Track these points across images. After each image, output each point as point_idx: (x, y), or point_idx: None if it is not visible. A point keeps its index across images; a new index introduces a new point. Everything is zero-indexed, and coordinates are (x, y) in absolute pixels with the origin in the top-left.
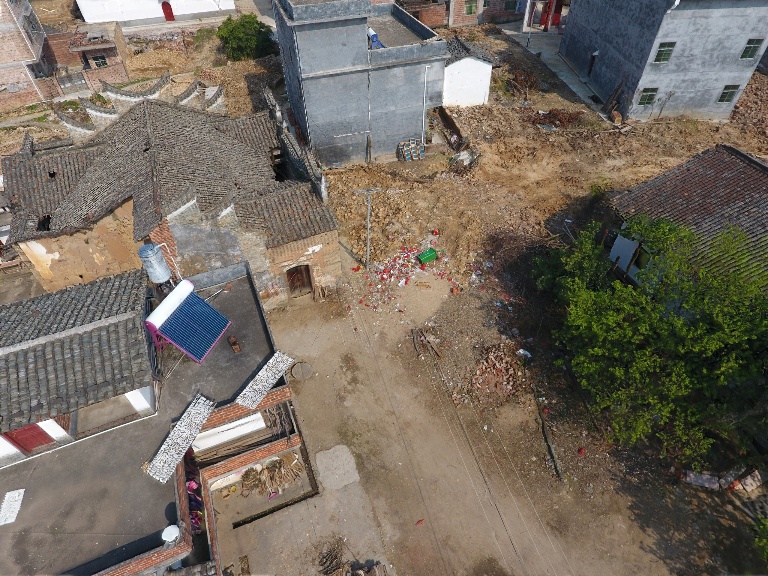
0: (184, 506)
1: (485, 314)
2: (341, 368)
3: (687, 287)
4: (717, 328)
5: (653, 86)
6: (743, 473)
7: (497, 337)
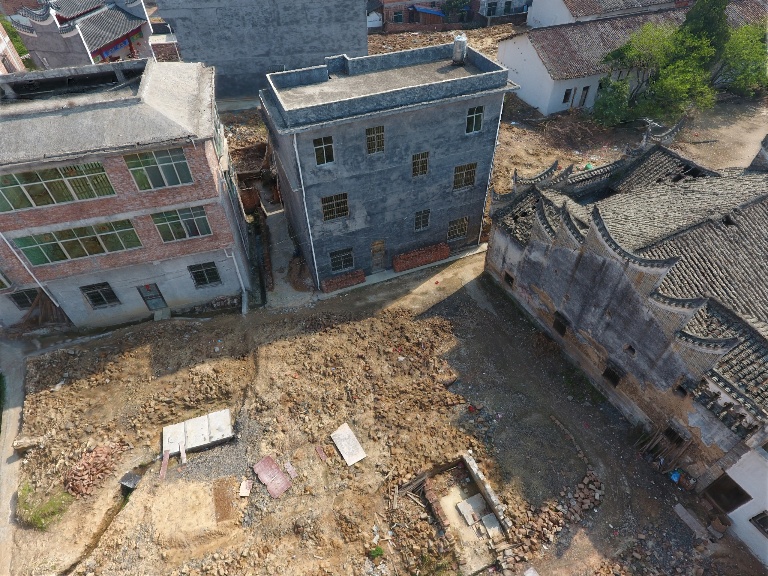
0: None
1: None
2: None
3: None
4: (689, 51)
5: None
6: None
7: None
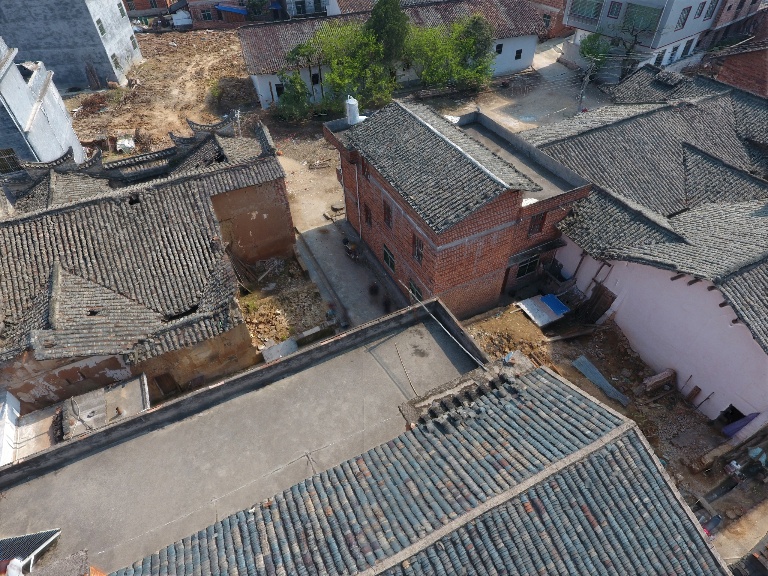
0: (465, 121)
1: (303, 143)
2: (336, 192)
3: (343, 47)
4: None
5: (112, 53)
6: (391, 99)
7: (320, 141)
